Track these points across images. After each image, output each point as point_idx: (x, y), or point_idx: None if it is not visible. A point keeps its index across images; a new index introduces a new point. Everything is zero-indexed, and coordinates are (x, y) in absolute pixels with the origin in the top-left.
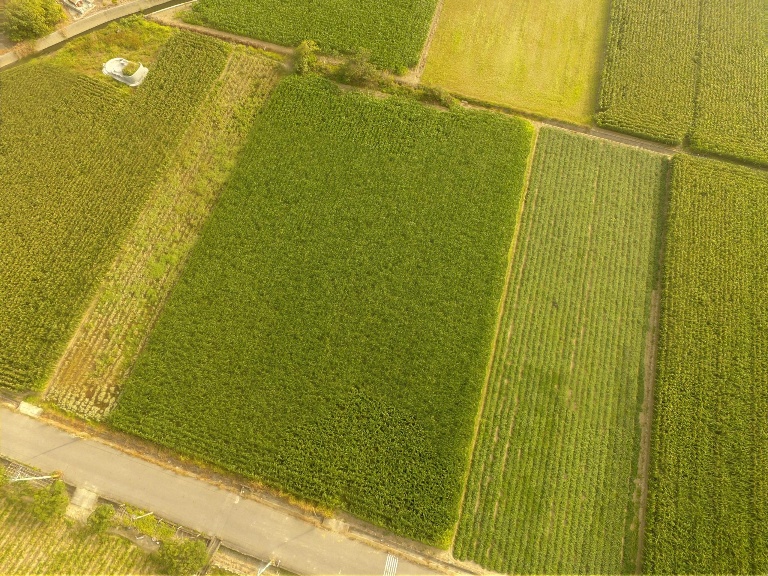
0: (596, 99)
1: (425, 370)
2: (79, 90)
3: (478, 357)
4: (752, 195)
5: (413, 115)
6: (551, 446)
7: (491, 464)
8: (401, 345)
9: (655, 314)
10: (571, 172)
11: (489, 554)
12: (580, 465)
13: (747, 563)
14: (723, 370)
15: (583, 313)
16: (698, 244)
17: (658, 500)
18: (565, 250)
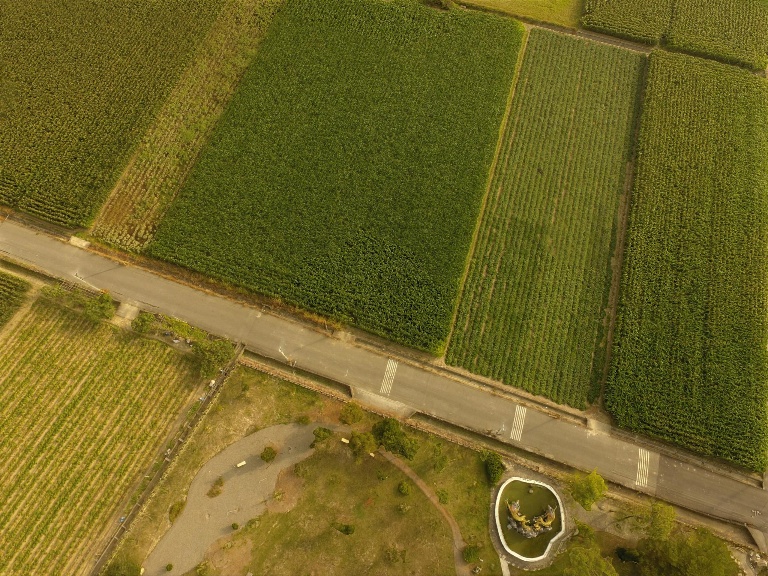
0: (583, 5)
1: (423, 217)
2: None
3: (470, 208)
4: (720, 84)
5: (416, 15)
6: (533, 281)
7: (480, 294)
8: (403, 197)
9: (629, 181)
10: (558, 65)
11: (476, 362)
12: (558, 296)
13: (699, 369)
14: (686, 222)
15: (565, 178)
16: (669, 123)
17: (624, 320)
18: (550, 128)
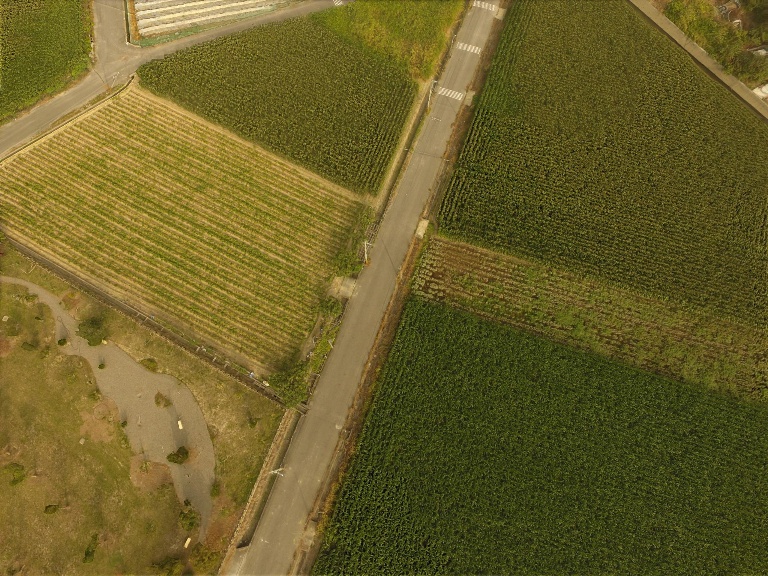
0: None
1: None
2: (766, 203)
3: None
4: None
5: None
6: None
7: None
8: None
9: None
10: None
11: None
12: None
13: None
14: None
15: None
16: None
17: None
18: None
